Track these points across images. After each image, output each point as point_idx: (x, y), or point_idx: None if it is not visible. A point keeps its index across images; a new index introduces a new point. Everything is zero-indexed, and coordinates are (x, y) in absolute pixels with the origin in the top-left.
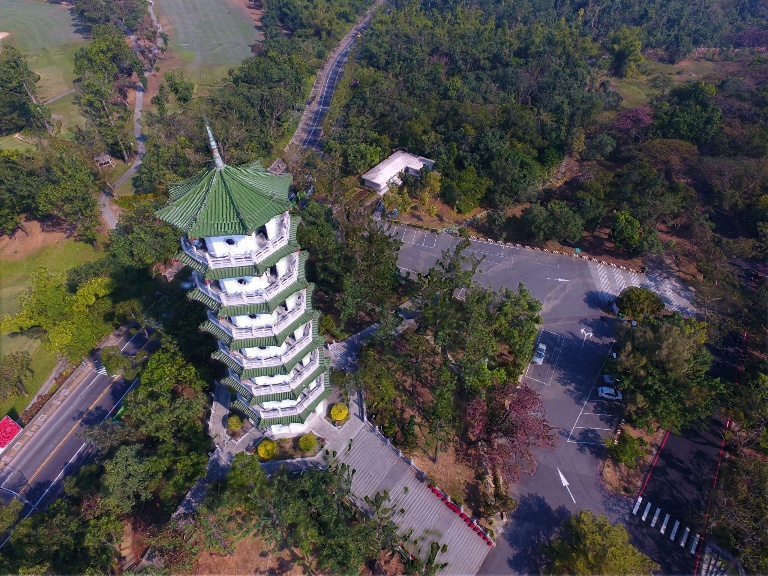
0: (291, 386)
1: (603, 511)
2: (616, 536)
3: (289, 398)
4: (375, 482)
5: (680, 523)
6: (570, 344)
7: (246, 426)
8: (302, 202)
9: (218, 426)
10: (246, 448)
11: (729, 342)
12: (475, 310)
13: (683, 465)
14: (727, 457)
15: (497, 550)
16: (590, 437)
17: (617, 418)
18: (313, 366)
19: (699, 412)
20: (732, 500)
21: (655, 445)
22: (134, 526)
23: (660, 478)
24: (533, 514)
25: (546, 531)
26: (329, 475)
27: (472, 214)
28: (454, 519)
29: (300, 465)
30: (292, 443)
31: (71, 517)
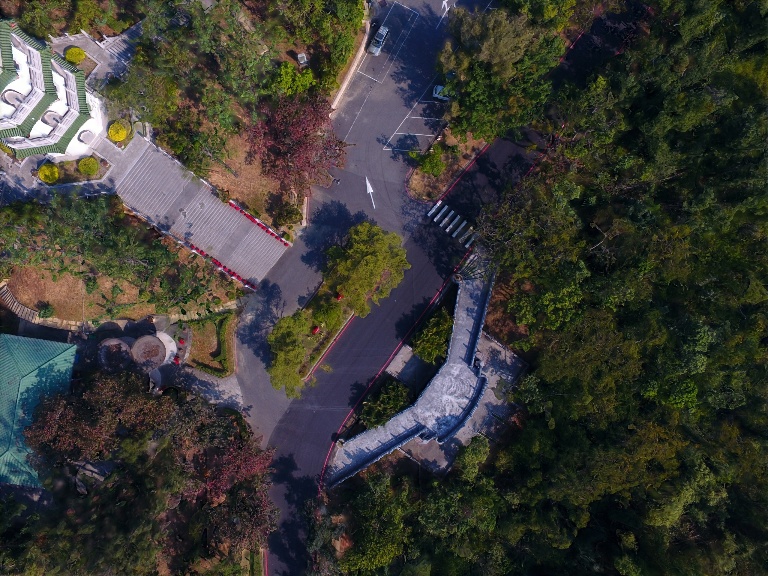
0: (13, 123)
1: (399, 214)
2: (382, 244)
3: (19, 135)
4: (170, 200)
5: (467, 223)
6: (422, 24)
7: None
8: None
9: None
10: (31, 171)
11: (626, 15)
12: (236, 6)
13: (495, 170)
14: (543, 161)
15: (293, 249)
16: (408, 144)
17: (444, 122)
18: (35, 96)
19: (513, 123)
20: (490, 217)
21: (477, 149)
22: None
23: (467, 183)
24: (332, 219)
25: (340, 233)
26: (113, 199)
27: None
28: (252, 227)
29: (87, 188)
30: (76, 166)
31: None
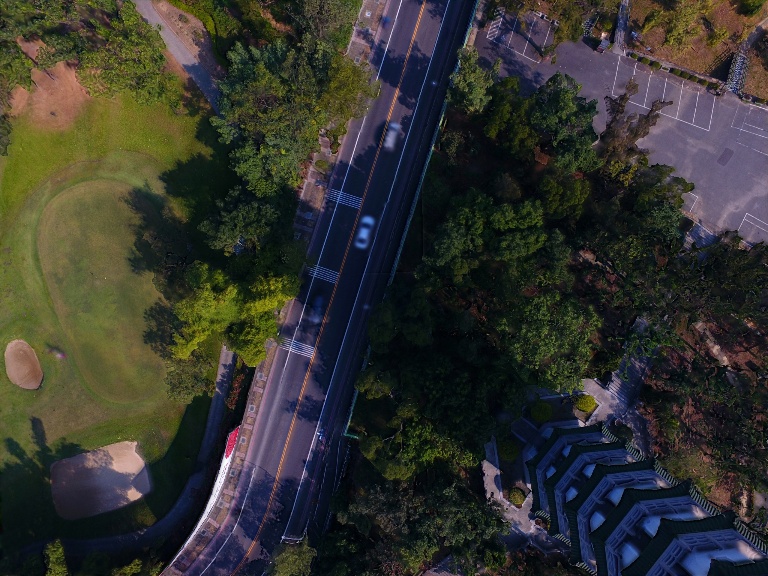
0: None
1: None
2: None
3: None
4: None
5: None
6: None
7: (523, 490)
8: (488, 1)
9: (492, 489)
10: (529, 515)
11: None
12: None
13: None
14: None
15: None
16: None
17: None
18: None
19: None
20: None
21: None
22: (423, 562)
23: None
24: None
25: None
26: None
27: (762, 14)
28: None
29: None
30: None
31: (375, 575)
